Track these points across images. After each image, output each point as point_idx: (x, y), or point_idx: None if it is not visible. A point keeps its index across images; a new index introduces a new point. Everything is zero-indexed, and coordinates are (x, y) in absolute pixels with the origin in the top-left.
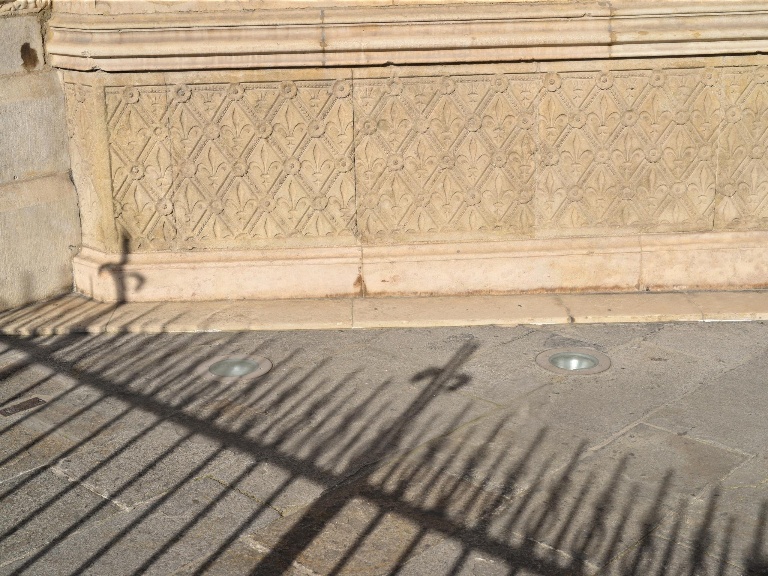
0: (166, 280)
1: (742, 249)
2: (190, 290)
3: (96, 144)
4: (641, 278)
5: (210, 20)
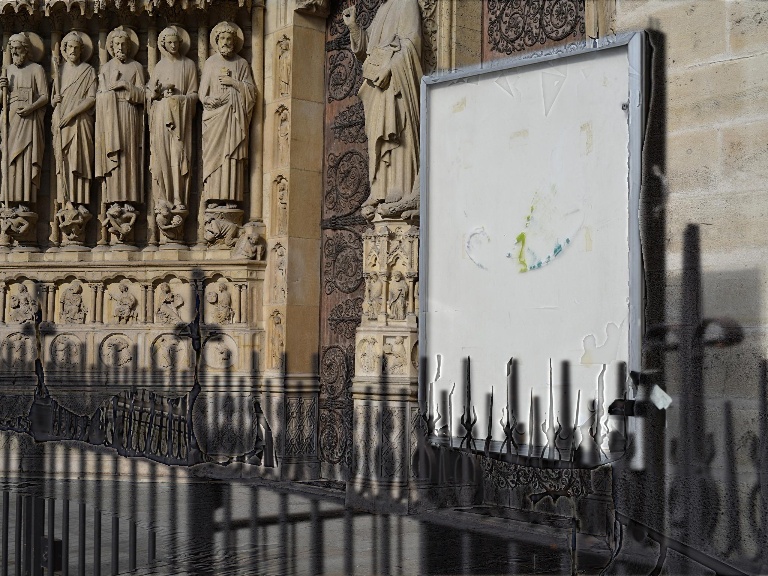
0: None
1: (152, 461)
2: None
3: None
4: (117, 470)
5: None
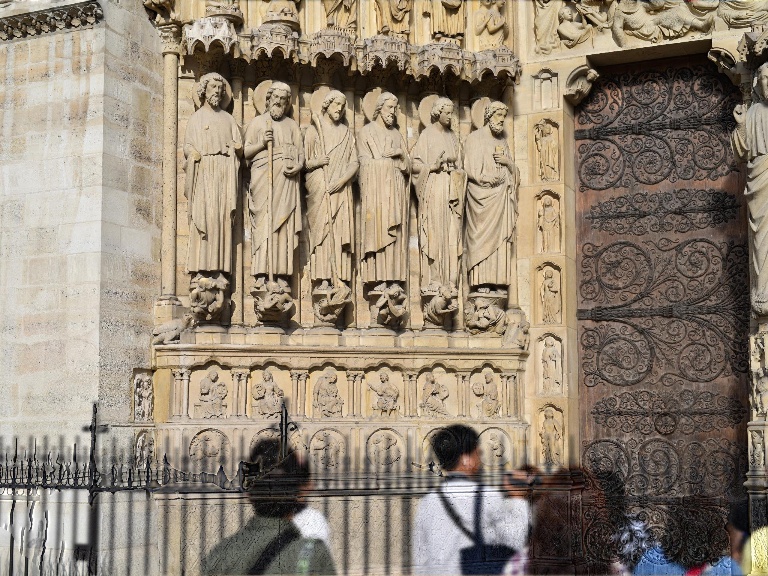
0: None
1: (432, 572)
2: None
3: (174, 530)
4: None
5: None
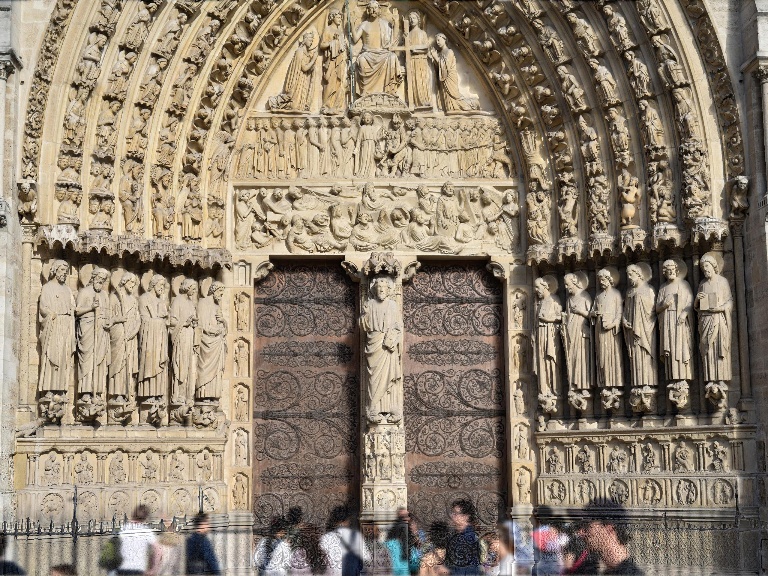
0: None
1: None
2: None
3: (31, 560)
4: None
5: None
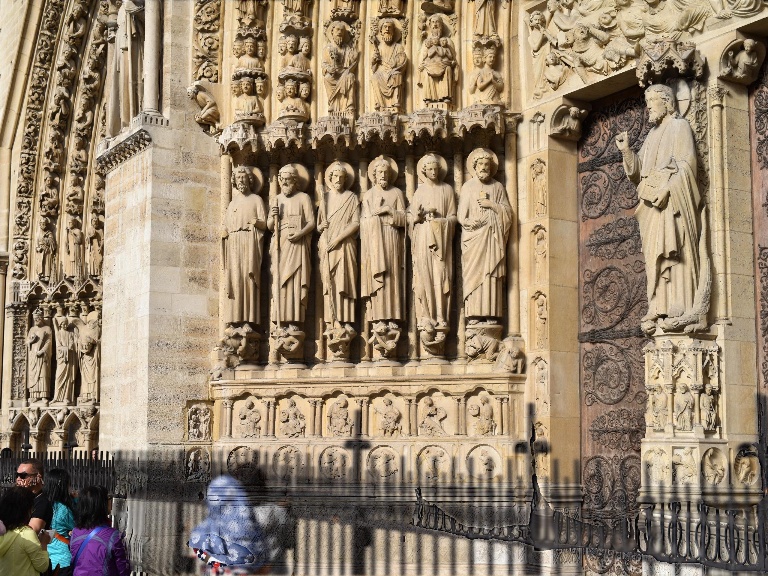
0: (232, 571)
1: (420, 570)
2: (239, 575)
3: None
4: None
5: (253, 485)
